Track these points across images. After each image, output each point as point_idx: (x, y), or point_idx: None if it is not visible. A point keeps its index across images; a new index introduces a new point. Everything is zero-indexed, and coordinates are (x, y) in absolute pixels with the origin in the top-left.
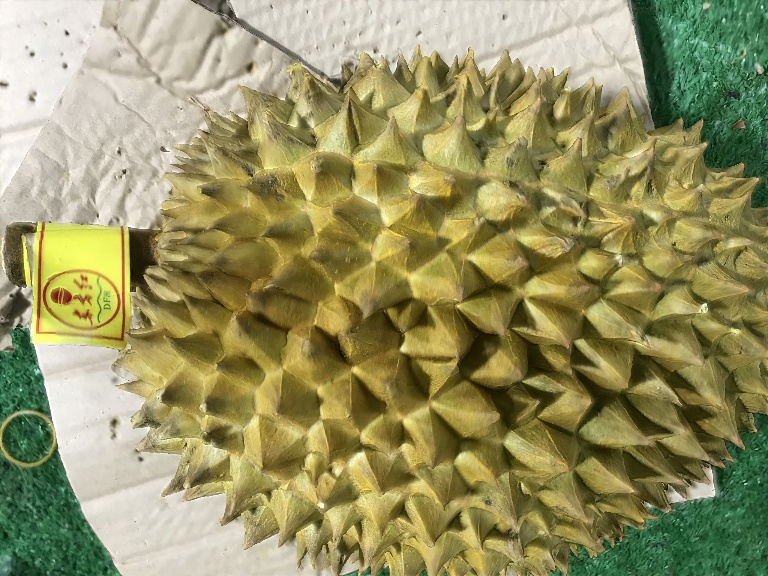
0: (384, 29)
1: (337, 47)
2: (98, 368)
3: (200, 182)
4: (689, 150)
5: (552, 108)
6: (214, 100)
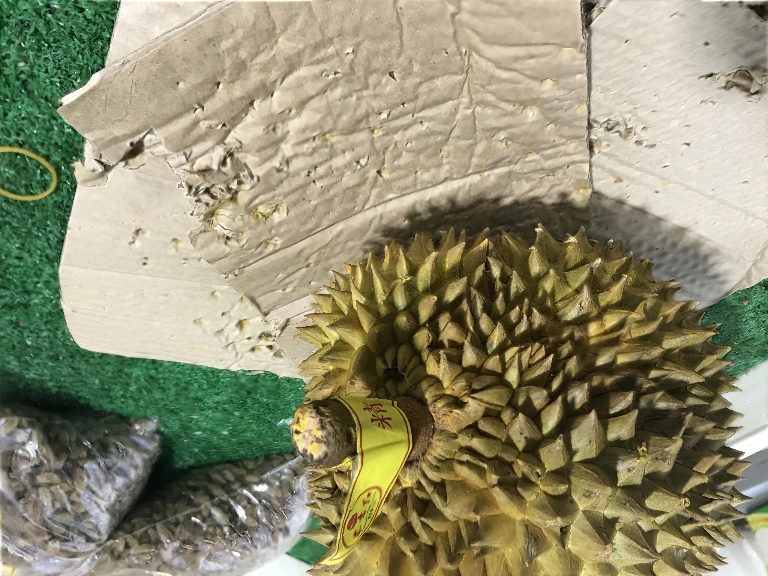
0: (672, 121)
1: (626, 105)
2: (152, 182)
3: (517, 510)
4: (734, 535)
5: (715, 492)
6: (484, 71)
